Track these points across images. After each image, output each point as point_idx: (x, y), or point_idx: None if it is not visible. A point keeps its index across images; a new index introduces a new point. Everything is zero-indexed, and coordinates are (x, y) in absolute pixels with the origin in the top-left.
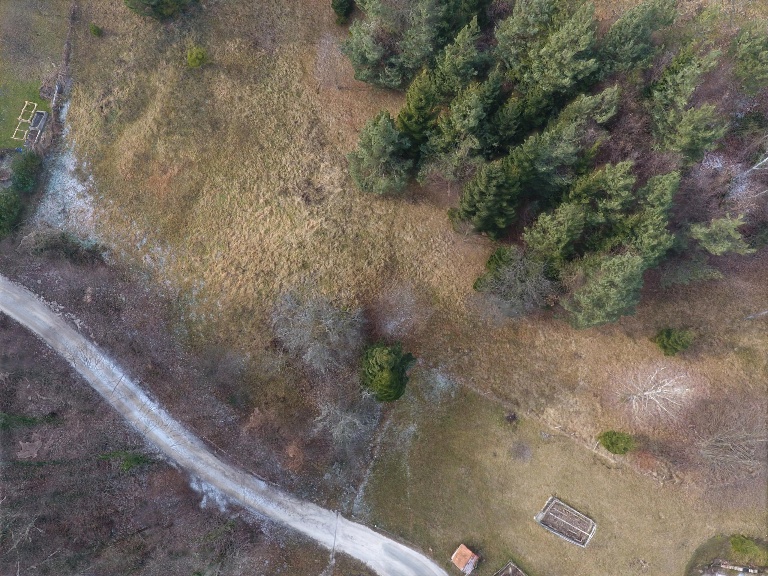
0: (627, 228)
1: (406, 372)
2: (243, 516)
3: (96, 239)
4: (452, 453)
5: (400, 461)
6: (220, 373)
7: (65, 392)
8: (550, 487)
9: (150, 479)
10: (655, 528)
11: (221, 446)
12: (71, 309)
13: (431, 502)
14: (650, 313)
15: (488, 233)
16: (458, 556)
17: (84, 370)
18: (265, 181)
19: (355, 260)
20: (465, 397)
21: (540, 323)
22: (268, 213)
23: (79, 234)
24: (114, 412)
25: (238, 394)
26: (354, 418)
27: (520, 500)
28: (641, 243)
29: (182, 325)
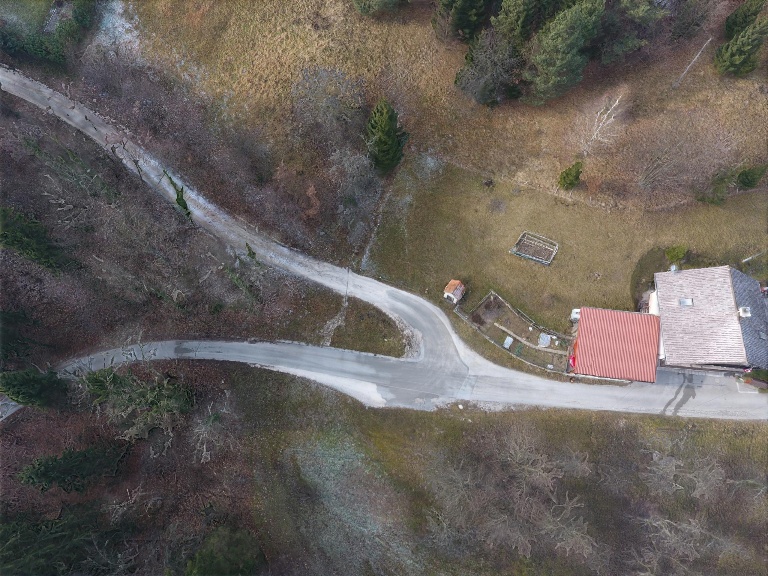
0: (570, 2)
1: (402, 158)
2: (270, 272)
3: (143, 62)
4: (441, 214)
5: (399, 225)
6: (249, 157)
7: (119, 184)
8: (521, 227)
9: (191, 251)
10: (605, 245)
11: (250, 221)
12: (122, 122)
13: (425, 255)
14: (597, 95)
15: (464, 31)
16: (449, 287)
17: (134, 167)
18: (281, 14)
19: (357, 68)
20: (451, 172)
21: (510, 111)
22: (284, 37)
23: (128, 59)
24: (160, 197)
25: (264, 174)
26: (361, 155)
27: (498, 241)
28: (581, 11)
29: (216, 124)
